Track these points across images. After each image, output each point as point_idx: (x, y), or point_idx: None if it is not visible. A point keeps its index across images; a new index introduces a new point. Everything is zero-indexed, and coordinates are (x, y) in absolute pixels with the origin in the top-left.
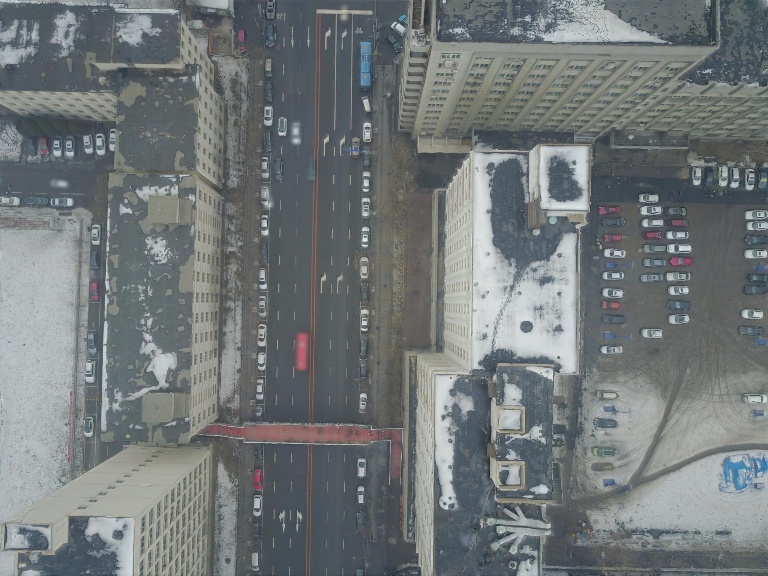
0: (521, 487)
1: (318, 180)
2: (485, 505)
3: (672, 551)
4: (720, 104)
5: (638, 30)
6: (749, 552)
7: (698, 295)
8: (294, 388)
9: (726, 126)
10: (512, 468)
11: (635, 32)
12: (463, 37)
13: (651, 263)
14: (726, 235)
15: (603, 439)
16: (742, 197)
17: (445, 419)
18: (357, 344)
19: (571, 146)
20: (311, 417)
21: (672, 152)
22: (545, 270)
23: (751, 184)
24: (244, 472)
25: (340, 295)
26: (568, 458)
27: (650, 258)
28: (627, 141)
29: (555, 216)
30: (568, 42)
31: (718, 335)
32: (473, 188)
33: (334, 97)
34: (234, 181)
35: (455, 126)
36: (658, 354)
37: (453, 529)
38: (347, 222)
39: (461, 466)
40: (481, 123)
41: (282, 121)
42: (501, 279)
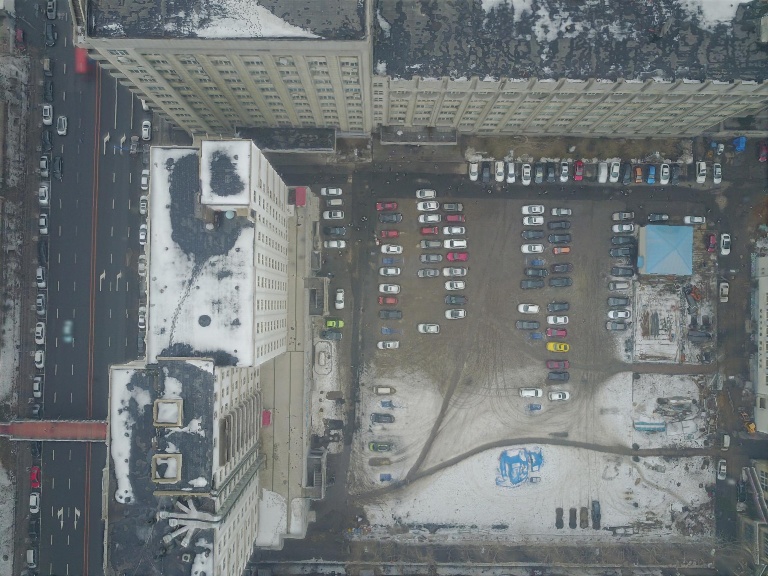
0: (174, 480)
1: (98, 178)
2: (161, 498)
3: (449, 545)
4: (448, 99)
5: (291, 25)
6: (526, 546)
7: (476, 290)
8: (73, 386)
9: (487, 121)
10: (171, 461)
11: (288, 27)
12: (118, 33)
13: (427, 258)
14: (504, 230)
15: (380, 434)
16: (520, 192)
17: (122, 413)
18: (135, 341)
19: (233, 141)
20: (89, 414)
21: (449, 148)
22: (223, 264)
23: (527, 179)
24: (22, 470)
25: (120, 293)
26: (346, 453)
27: (427, 254)
28: (396, 137)
29: (232, 211)
30: (219, 38)
31: (495, 330)
32: (151, 183)
33: (115, 96)
34: (14, 180)
35: (217, 123)
36: (435, 349)
37: (129, 523)
38: (127, 220)
39: (138, 460)
40: (239, 120)
41: (60, 120)
42: (179, 274)
